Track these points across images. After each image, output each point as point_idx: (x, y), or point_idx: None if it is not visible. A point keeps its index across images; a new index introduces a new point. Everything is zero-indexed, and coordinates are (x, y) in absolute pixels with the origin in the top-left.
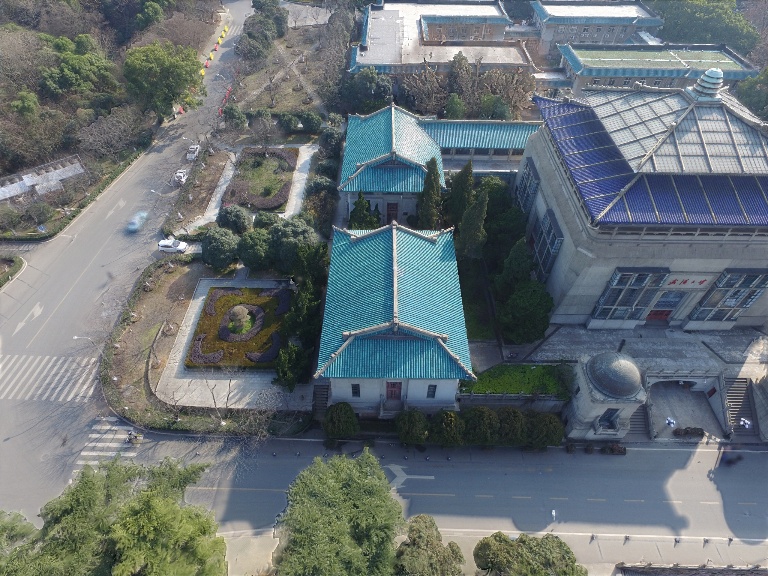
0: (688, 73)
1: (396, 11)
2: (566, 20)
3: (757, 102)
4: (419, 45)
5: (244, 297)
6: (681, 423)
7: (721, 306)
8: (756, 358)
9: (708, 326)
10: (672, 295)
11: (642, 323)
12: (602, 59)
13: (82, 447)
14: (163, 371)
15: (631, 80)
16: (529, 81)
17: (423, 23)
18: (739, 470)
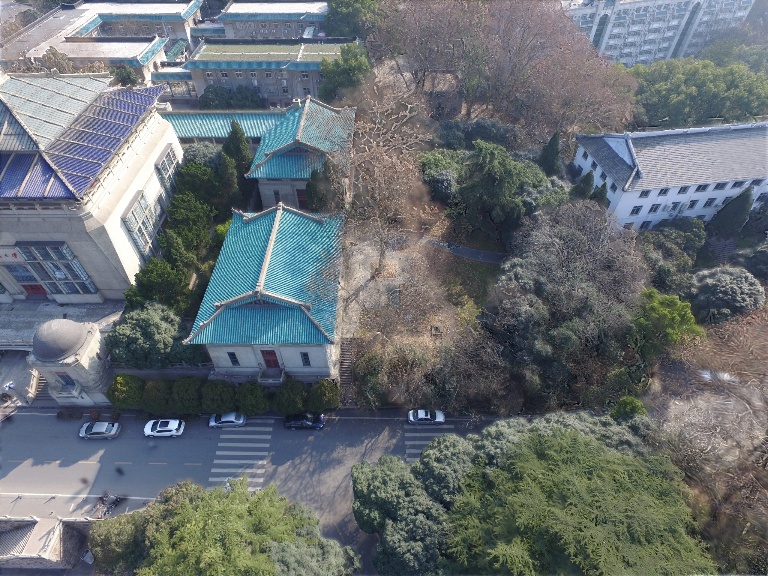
0: (286, 65)
1: (85, 10)
2: (238, 16)
3: (321, 91)
4: (61, 42)
5: None
6: (0, 389)
7: (59, 279)
8: (98, 328)
9: (77, 299)
10: (20, 269)
11: (22, 297)
12: (224, 53)
13: None
14: None
15: (242, 72)
16: (126, 74)
17: (92, 21)
18: (8, 431)
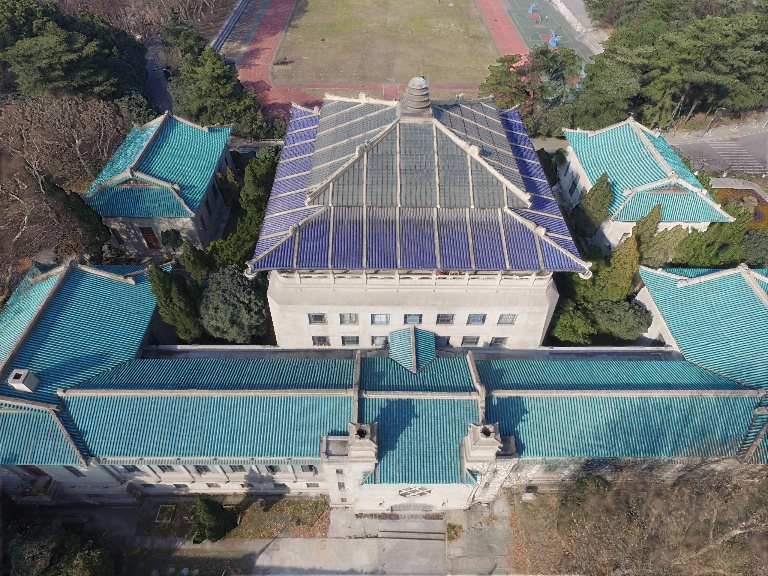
0: None
1: None
2: None
3: None
4: None
5: (762, 227)
6: None
7: None
8: None
9: None
10: None
11: None
12: None
13: (767, 168)
14: (766, 193)
15: None
16: None
17: None
18: None
